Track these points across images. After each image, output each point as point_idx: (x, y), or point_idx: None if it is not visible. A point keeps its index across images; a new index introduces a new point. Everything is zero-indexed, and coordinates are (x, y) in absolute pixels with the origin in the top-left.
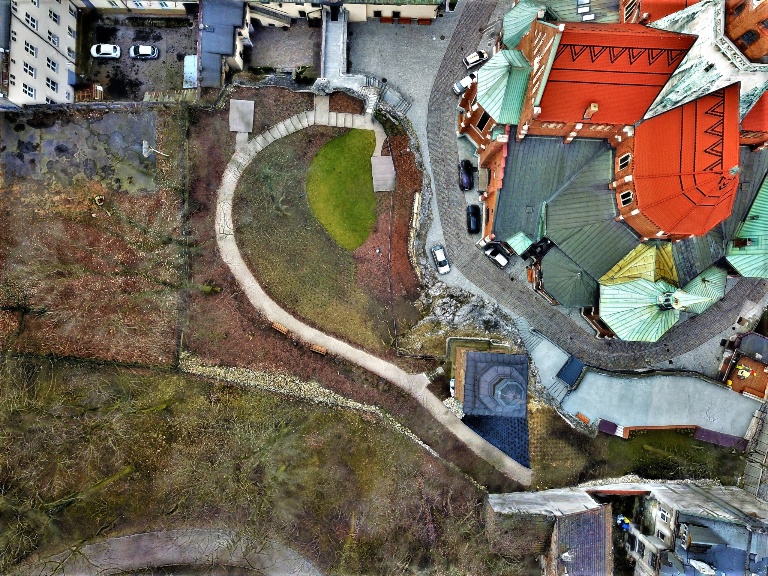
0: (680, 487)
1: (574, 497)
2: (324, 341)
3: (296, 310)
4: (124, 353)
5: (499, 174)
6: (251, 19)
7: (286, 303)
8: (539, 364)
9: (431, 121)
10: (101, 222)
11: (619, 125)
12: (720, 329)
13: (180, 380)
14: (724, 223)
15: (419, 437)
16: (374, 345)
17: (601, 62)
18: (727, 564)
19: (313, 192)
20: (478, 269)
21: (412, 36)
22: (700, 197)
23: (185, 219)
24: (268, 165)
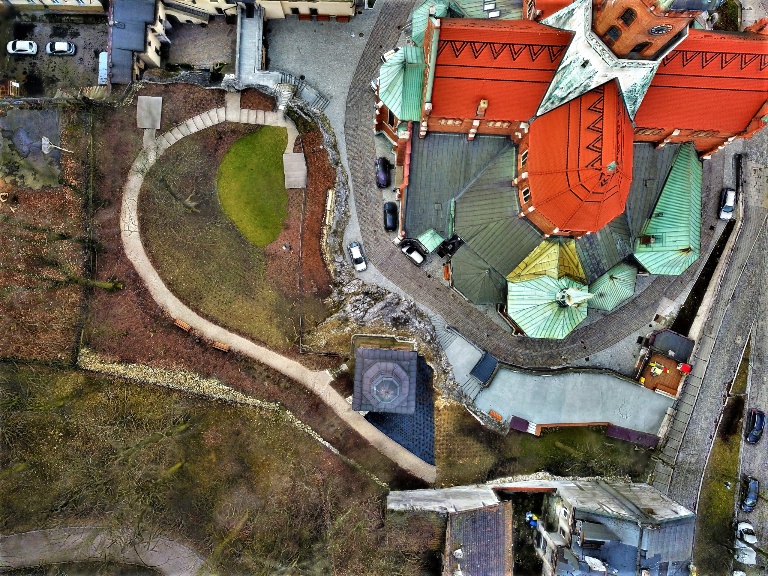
0: (589, 484)
1: (477, 494)
2: (227, 338)
3: (199, 307)
4: (23, 350)
5: (405, 171)
6: (167, 16)
7: (189, 300)
8: (453, 361)
9: (349, 118)
10: (5, 219)
11: (516, 122)
12: (637, 326)
13: (78, 377)
14: (631, 220)
15: (319, 434)
16: (277, 342)
17: (484, 58)
18: (619, 560)
19: (224, 189)
20: (395, 266)
21: (331, 33)
22: (585, 193)
23: (89, 216)
24: (177, 162)
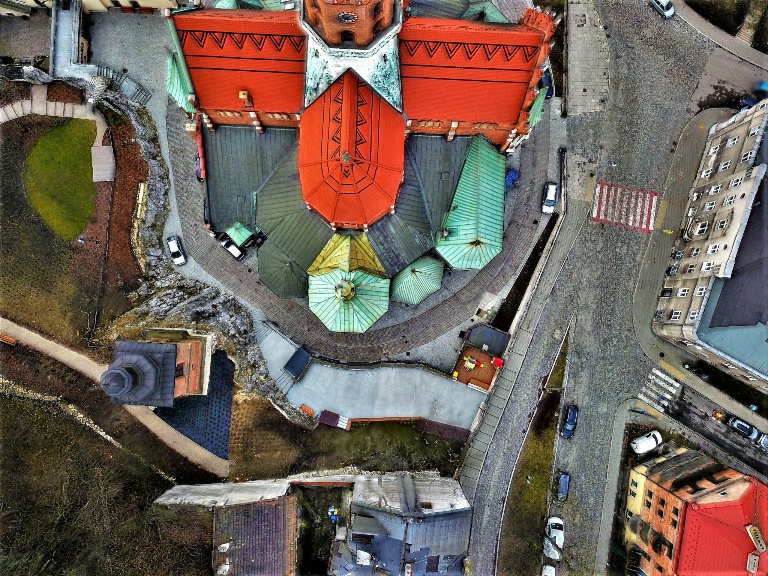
0: (393, 479)
1: (266, 488)
2: (16, 332)
3: None
4: None
5: (201, 164)
6: None
7: None
8: (267, 356)
9: (171, 112)
10: None
11: (292, 114)
12: (459, 321)
13: None
14: (430, 213)
15: (102, 428)
16: (67, 336)
17: (230, 48)
18: (387, 554)
19: (31, 182)
20: (216, 260)
21: (155, 26)
22: (336, 185)
23: None
24: None
